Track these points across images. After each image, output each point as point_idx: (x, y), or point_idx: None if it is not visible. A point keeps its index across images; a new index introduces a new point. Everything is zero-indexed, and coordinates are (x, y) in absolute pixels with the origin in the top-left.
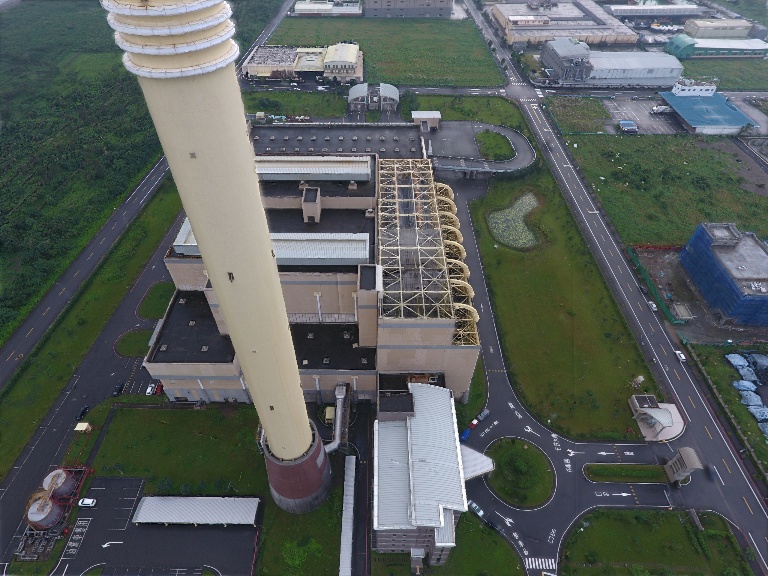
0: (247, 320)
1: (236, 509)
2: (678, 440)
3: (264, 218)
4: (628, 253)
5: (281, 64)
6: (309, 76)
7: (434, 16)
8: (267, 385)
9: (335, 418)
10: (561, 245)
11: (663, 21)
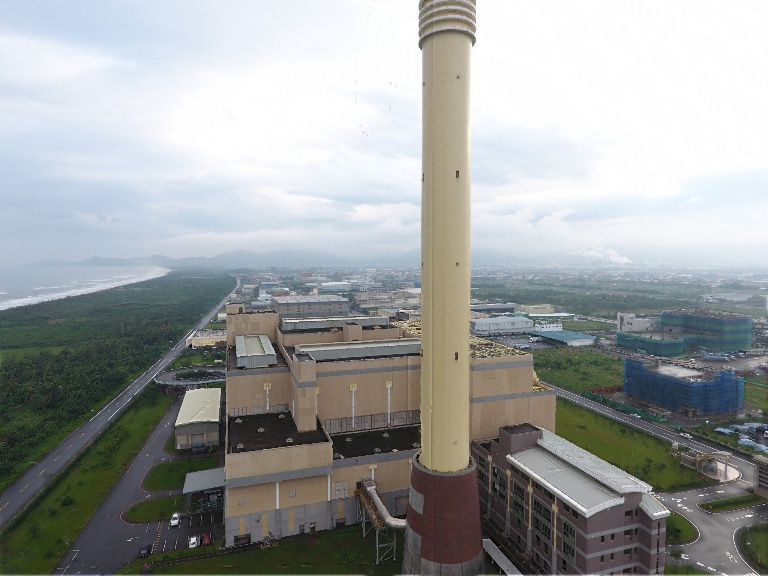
0: (459, 223)
1: None
2: (743, 477)
3: None
4: (587, 396)
5: None
6: None
7: None
8: (458, 316)
9: None
10: None
11: (497, 312)
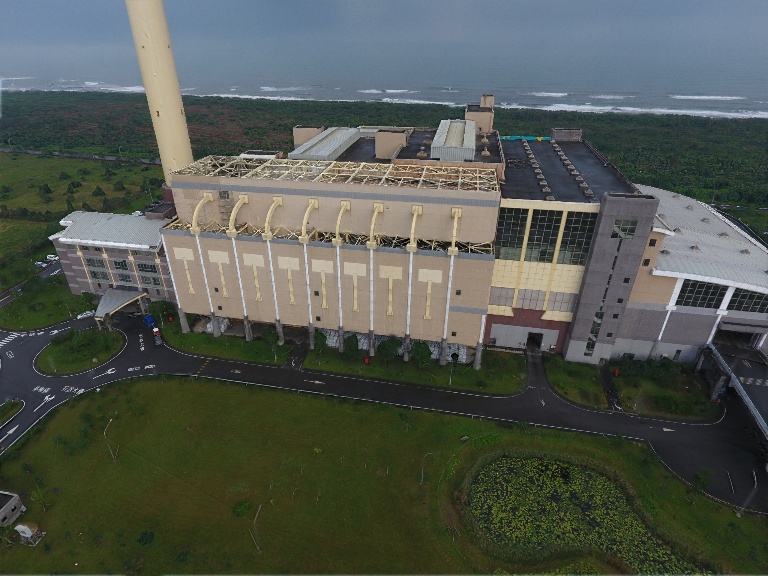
0: None
1: None
2: None
3: None
4: None
5: None
6: None
7: None
8: None
9: None
10: None
11: None
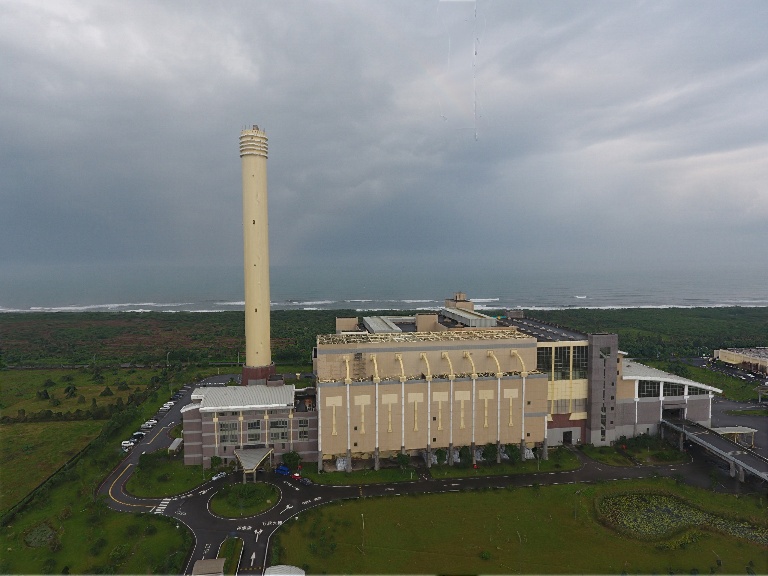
0: None
1: None
2: None
3: (255, 208)
4: None
5: None
6: None
7: None
8: None
9: None
10: (662, 562)
11: None
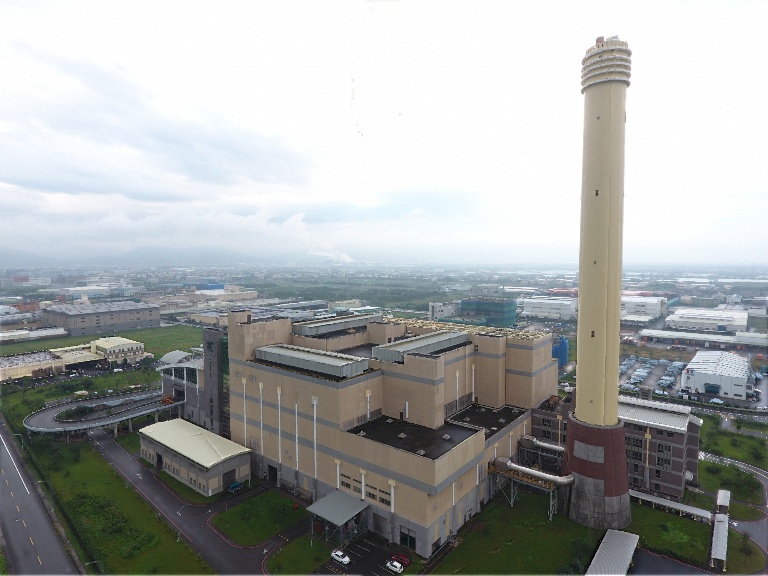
0: None
1: (618, 542)
2: None
3: None
4: None
5: (44, 362)
6: (82, 369)
7: (145, 327)
8: None
9: (554, 449)
10: None
11: (310, 309)
